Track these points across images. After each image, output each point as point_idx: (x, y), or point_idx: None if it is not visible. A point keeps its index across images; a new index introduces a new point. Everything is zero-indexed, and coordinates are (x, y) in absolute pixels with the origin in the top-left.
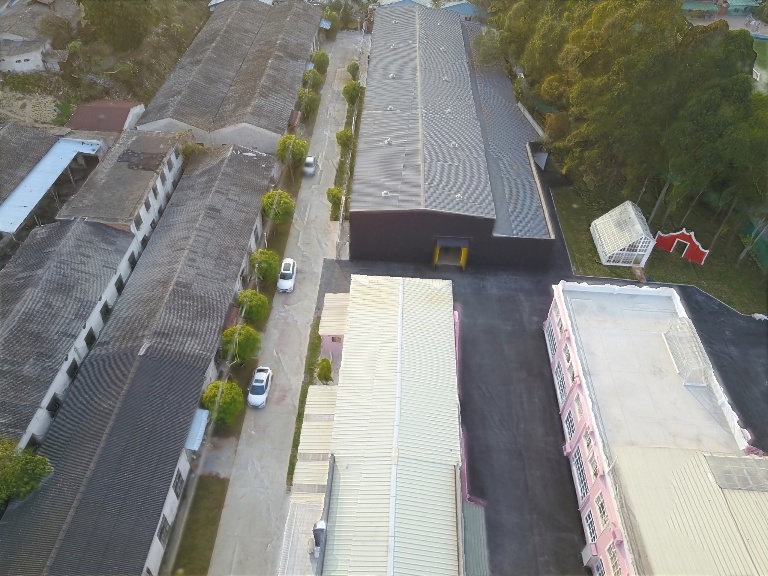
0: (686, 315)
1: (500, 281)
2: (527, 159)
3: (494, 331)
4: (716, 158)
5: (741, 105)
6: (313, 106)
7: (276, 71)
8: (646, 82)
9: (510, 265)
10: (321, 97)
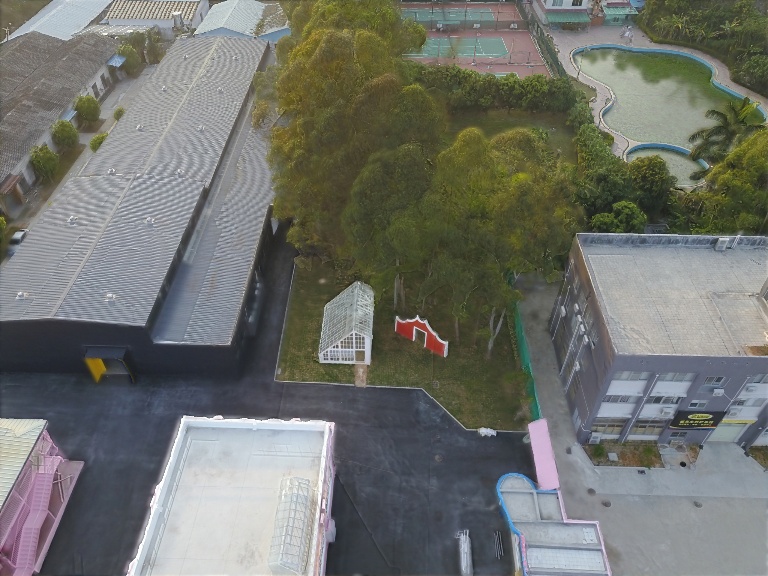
0: (322, 464)
1: (174, 395)
2: (260, 228)
3: (131, 471)
4: (390, 249)
5: (408, 183)
6: (49, 166)
7: (11, 126)
8: (324, 150)
9: (193, 373)
10: (84, 149)
